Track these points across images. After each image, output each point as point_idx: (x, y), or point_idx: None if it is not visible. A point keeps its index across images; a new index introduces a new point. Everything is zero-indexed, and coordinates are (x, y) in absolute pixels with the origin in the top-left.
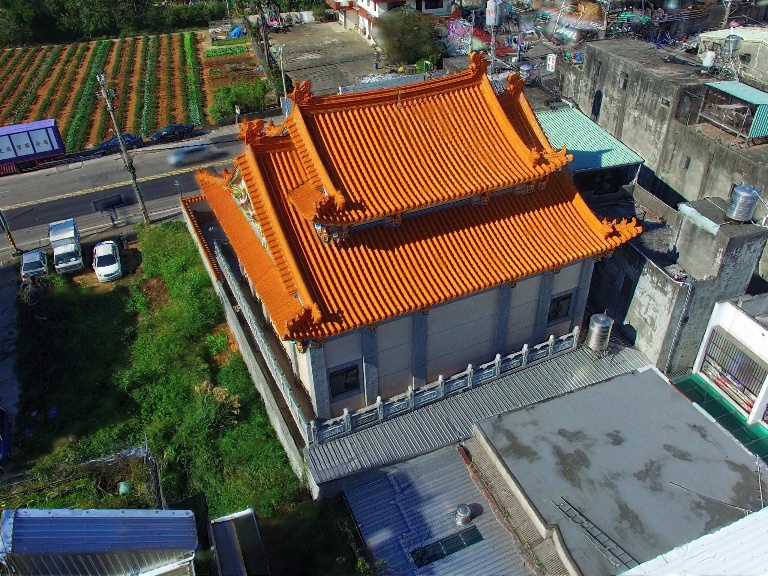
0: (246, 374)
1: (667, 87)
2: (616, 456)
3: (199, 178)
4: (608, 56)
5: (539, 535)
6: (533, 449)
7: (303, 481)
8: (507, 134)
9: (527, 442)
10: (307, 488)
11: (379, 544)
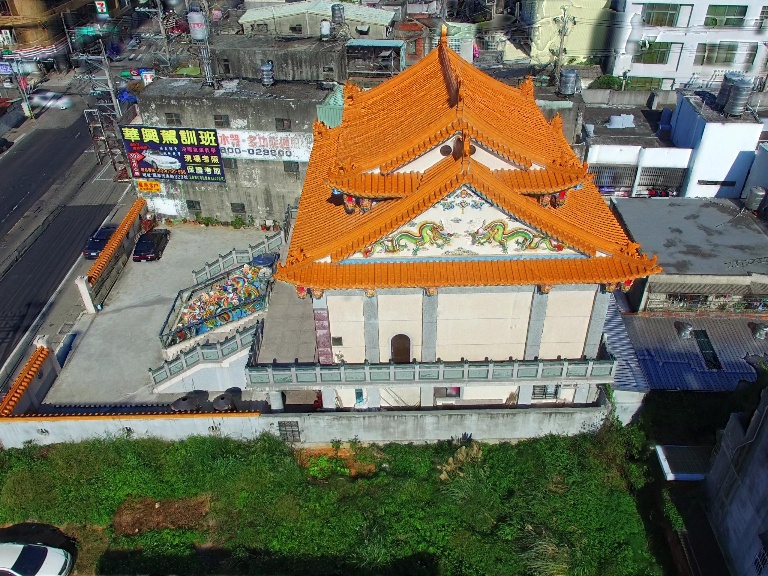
0: (409, 446)
1: (326, 56)
2: (692, 236)
3: (282, 276)
4: (237, 51)
5: (746, 286)
6: (681, 260)
7: (608, 419)
8: (490, 85)
9: (674, 261)
10: (611, 422)
11: (699, 383)
